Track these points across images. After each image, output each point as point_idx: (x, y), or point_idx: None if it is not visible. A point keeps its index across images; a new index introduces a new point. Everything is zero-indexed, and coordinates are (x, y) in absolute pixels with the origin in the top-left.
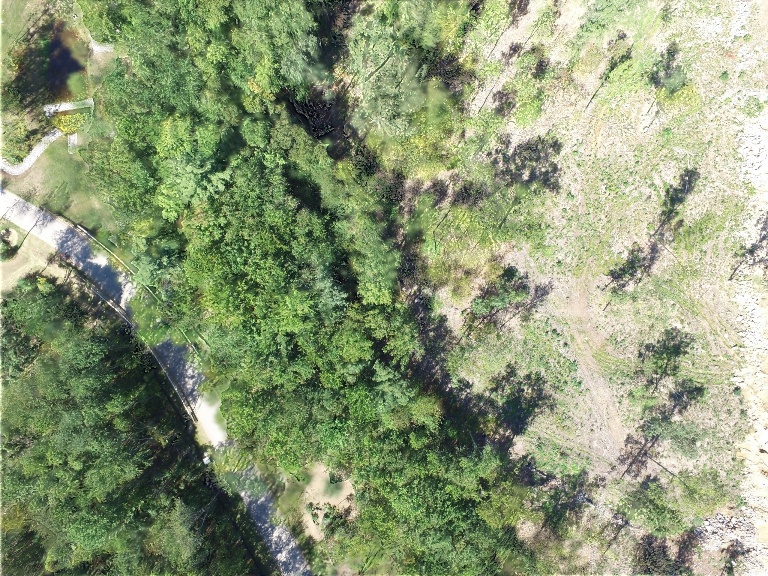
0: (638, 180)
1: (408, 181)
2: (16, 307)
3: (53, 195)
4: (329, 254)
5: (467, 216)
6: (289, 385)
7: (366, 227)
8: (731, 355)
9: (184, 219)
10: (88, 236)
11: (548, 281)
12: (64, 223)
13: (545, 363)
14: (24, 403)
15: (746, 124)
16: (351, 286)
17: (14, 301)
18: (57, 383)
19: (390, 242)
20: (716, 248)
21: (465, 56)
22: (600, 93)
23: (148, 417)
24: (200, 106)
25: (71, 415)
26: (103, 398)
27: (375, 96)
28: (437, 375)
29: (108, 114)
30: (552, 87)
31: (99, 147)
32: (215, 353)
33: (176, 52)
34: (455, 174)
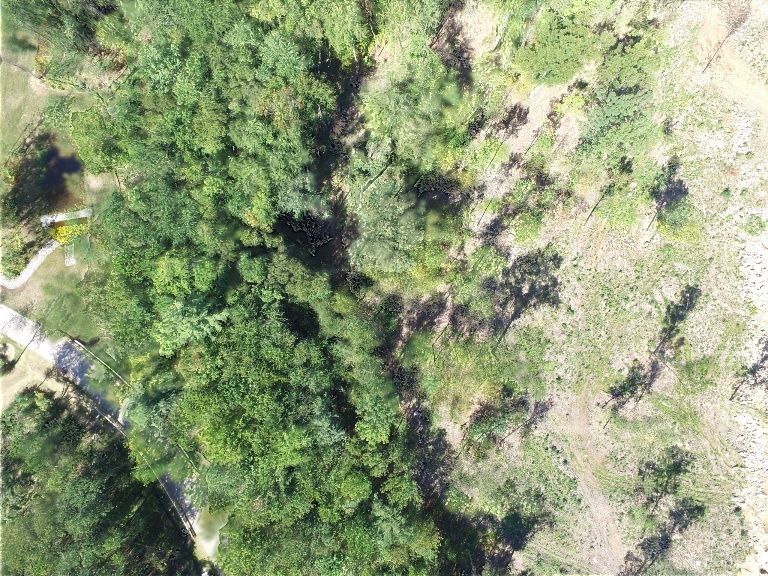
0: (639, 296)
1: (407, 293)
2: (14, 422)
3: (50, 309)
4: (327, 382)
5: (466, 329)
6: (287, 520)
7: (364, 358)
8: (732, 475)
9: (181, 362)
10: (85, 351)
11: (548, 397)
12: (61, 338)
13: (545, 480)
14: (21, 546)
15: (748, 242)
16: (349, 418)
17: (12, 416)
18: (54, 525)
19: (389, 357)
20: (717, 367)
21: (464, 166)
22: (600, 206)
23: (146, 536)
24: (197, 239)
25: (69, 557)
26: (101, 533)
27: (373, 206)
28: (436, 489)
29: (104, 247)
30: (552, 200)
31: (95, 278)
32: (213, 493)
33: (172, 185)
34: (454, 286)
